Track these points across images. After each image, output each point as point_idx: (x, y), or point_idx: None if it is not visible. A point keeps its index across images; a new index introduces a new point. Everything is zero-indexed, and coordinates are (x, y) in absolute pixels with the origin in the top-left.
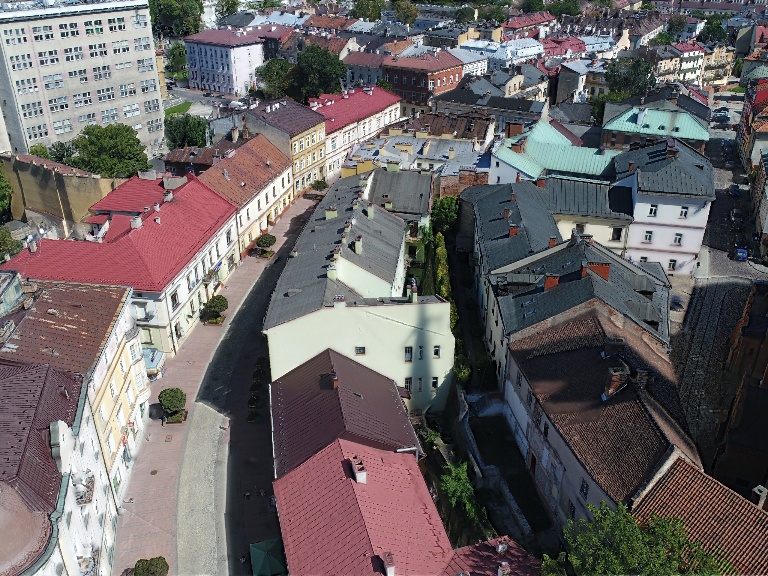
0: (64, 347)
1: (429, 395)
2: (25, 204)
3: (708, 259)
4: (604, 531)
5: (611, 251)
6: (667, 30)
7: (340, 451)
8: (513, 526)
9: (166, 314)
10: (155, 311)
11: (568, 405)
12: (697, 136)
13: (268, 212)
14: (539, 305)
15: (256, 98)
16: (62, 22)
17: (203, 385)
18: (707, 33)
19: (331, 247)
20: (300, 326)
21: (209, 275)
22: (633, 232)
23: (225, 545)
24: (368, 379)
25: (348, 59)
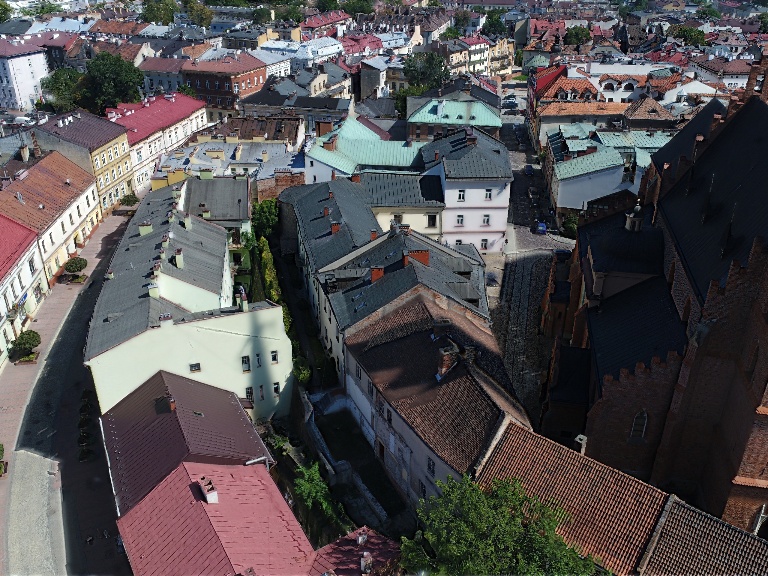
0: None
1: (272, 402)
2: None
3: (514, 235)
4: (453, 503)
5: (428, 238)
6: (454, 25)
7: (186, 475)
8: (370, 515)
9: None
10: None
11: (407, 390)
12: (491, 123)
13: (74, 234)
14: (368, 298)
15: None
16: None
17: (22, 431)
18: (489, 27)
19: (150, 264)
20: (126, 351)
21: (14, 310)
22: (446, 217)
23: None
24: (207, 395)
25: (144, 65)
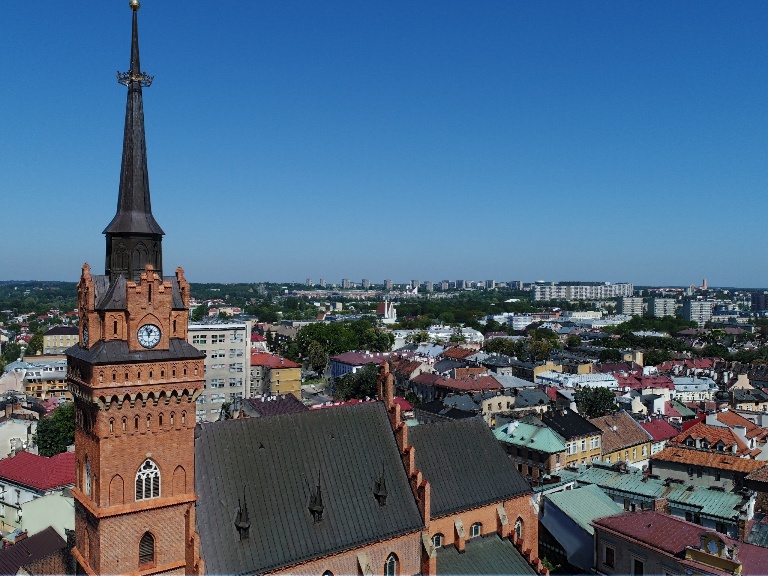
0: None
1: None
2: None
3: None
4: None
5: None
6: None
7: None
8: None
9: None
10: None
11: None
12: (545, 448)
13: None
14: None
15: None
16: None
17: None
18: None
19: None
20: (38, 505)
21: None
22: None
23: None
24: None
25: (417, 378)
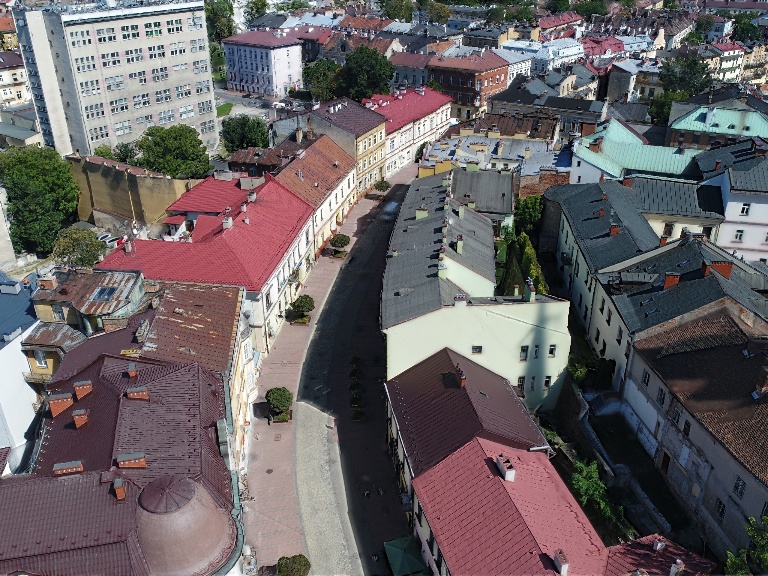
0: (198, 346)
1: (541, 394)
2: (93, 205)
3: None
4: None
5: (723, 250)
6: (695, 29)
7: (481, 449)
8: (651, 524)
9: (262, 314)
10: (252, 311)
11: (714, 403)
12: None
13: (337, 212)
14: (661, 304)
15: (296, 99)
16: (124, 24)
17: (301, 384)
18: (741, 32)
19: (432, 247)
20: (420, 325)
21: (293, 275)
22: (723, 231)
23: (354, 543)
24: (486, 378)
25: (392, 60)
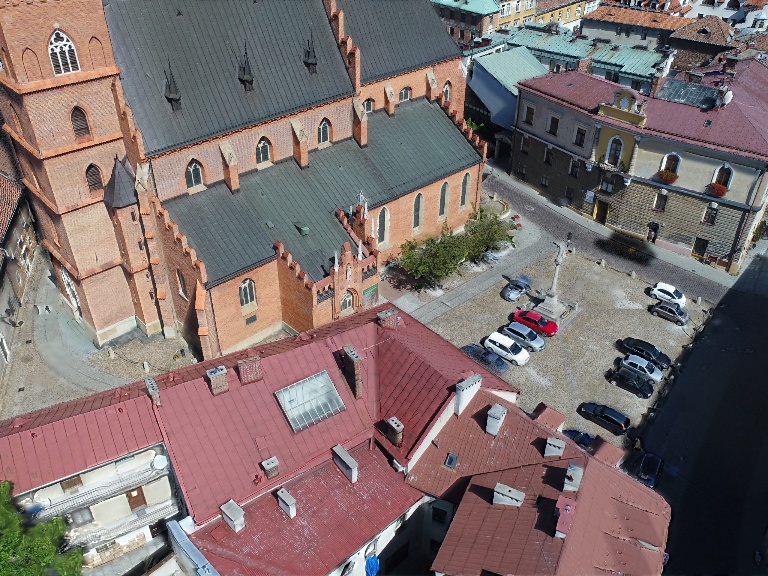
0: None
1: None
2: None
3: None
4: None
5: None
6: None
7: None
8: None
9: None
10: None
11: None
12: (478, 10)
13: None
14: None
15: None
16: None
17: None
18: None
19: None
20: None
21: None
22: None
23: None
24: None
25: None
